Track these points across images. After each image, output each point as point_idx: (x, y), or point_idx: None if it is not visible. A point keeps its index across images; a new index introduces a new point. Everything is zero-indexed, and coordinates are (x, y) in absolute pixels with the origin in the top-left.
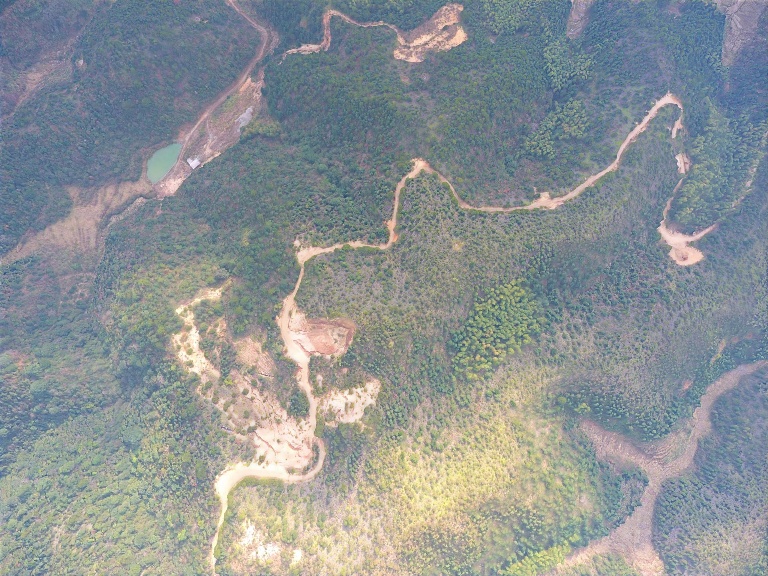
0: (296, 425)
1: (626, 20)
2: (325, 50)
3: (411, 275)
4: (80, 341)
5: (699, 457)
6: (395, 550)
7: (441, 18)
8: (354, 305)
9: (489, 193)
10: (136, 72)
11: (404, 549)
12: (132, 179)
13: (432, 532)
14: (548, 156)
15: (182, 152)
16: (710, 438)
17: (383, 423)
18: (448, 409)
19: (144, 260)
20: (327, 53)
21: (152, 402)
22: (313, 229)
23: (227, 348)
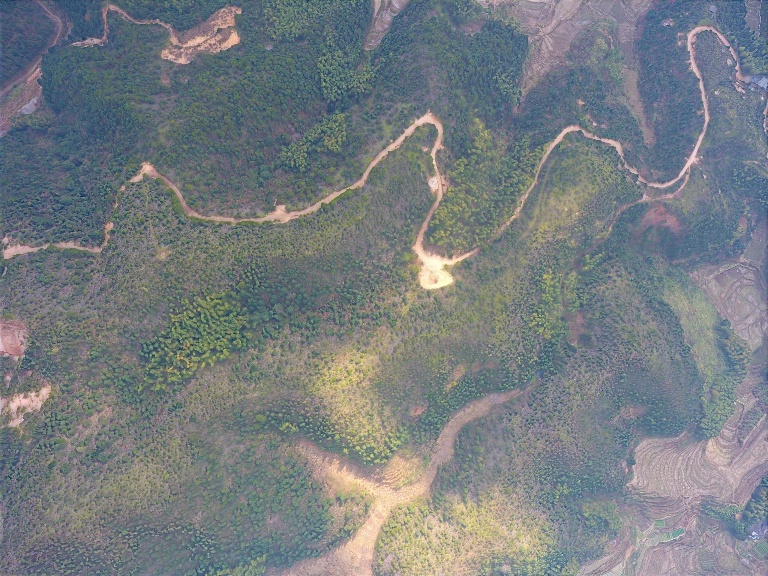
0: None
1: (411, 35)
2: None
3: (110, 281)
4: None
5: (435, 484)
6: (17, 560)
7: (218, 20)
8: (28, 308)
9: (226, 202)
10: None
11: (26, 560)
12: None
13: (62, 545)
14: (300, 168)
15: None
16: (448, 466)
17: (38, 430)
18: (128, 420)
19: None
20: (101, 48)
21: None
22: (30, 227)
23: None
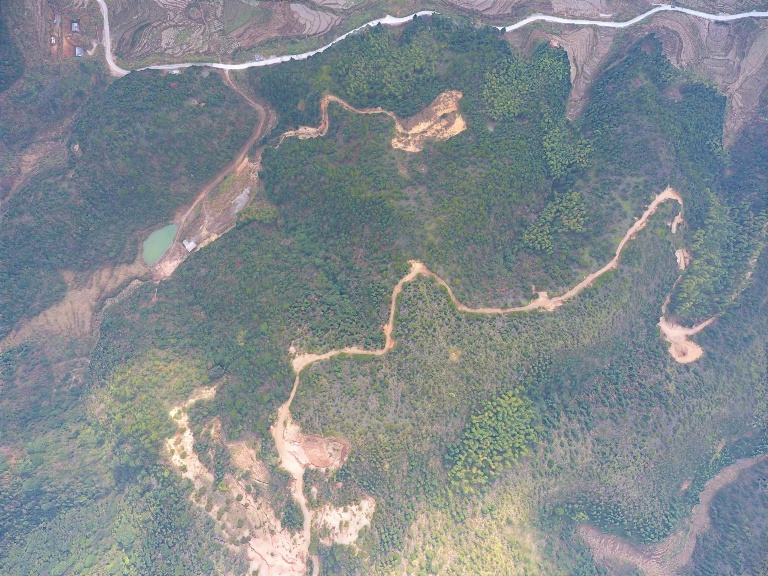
0: (290, 538)
1: (626, 106)
2: (323, 134)
3: (407, 386)
4: (73, 433)
5: (698, 555)
6: None
7: (440, 105)
8: (349, 424)
9: (487, 292)
10: (132, 161)
11: None
12: (127, 262)
13: None
14: (547, 251)
15: (178, 234)
16: (709, 535)
17: (378, 548)
18: (444, 525)
19: (138, 356)
20: (325, 139)
21: (145, 502)
22: (309, 333)
23: (221, 452)
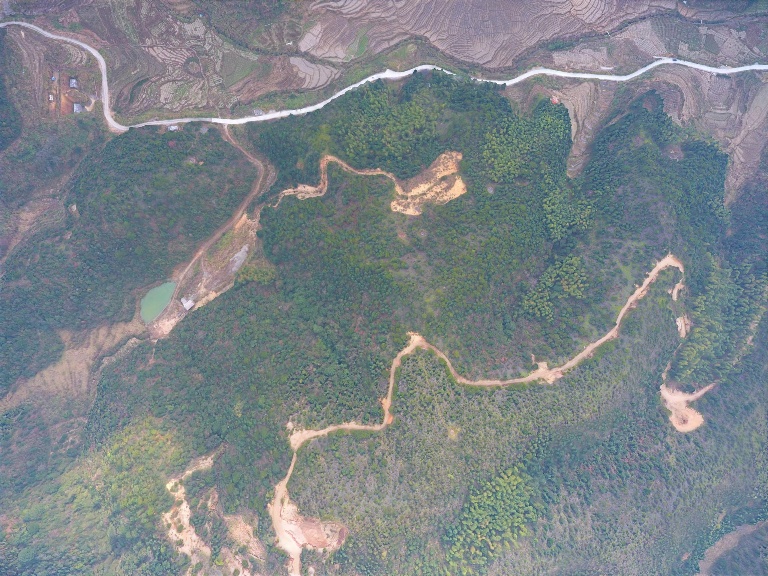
0: None
1: (627, 167)
2: (322, 194)
3: (406, 465)
4: (70, 497)
5: None
6: None
7: (439, 167)
8: (347, 508)
9: (486, 362)
10: (129, 224)
11: None
12: (125, 320)
13: None
14: (547, 318)
15: (176, 291)
16: None
17: None
18: None
19: (135, 424)
20: (324, 200)
21: (141, 574)
22: (307, 407)
23: (218, 525)
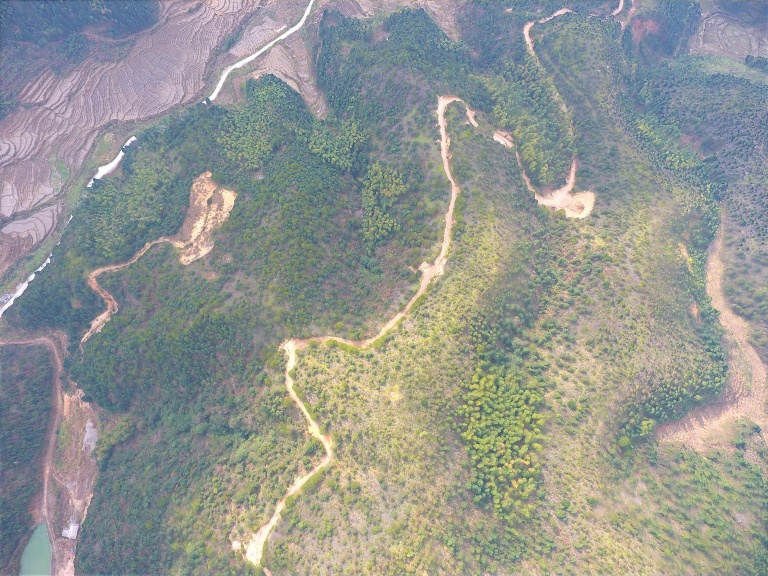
0: None
1: (353, 72)
2: (116, 311)
3: (377, 467)
4: None
5: (765, 356)
6: None
7: (199, 197)
8: (350, 569)
9: (376, 309)
10: None
11: None
12: None
13: None
14: (395, 229)
15: (50, 532)
16: (755, 331)
17: None
18: (540, 572)
19: None
20: (119, 313)
21: None
22: (241, 510)
23: None
